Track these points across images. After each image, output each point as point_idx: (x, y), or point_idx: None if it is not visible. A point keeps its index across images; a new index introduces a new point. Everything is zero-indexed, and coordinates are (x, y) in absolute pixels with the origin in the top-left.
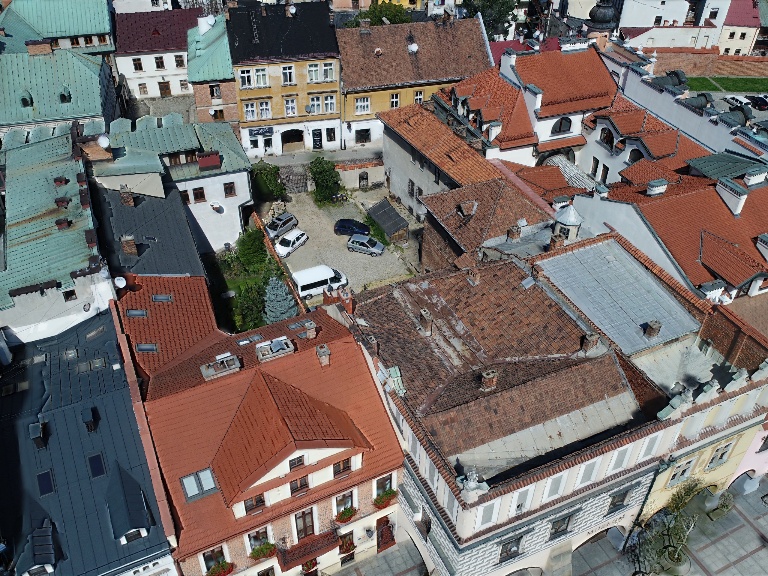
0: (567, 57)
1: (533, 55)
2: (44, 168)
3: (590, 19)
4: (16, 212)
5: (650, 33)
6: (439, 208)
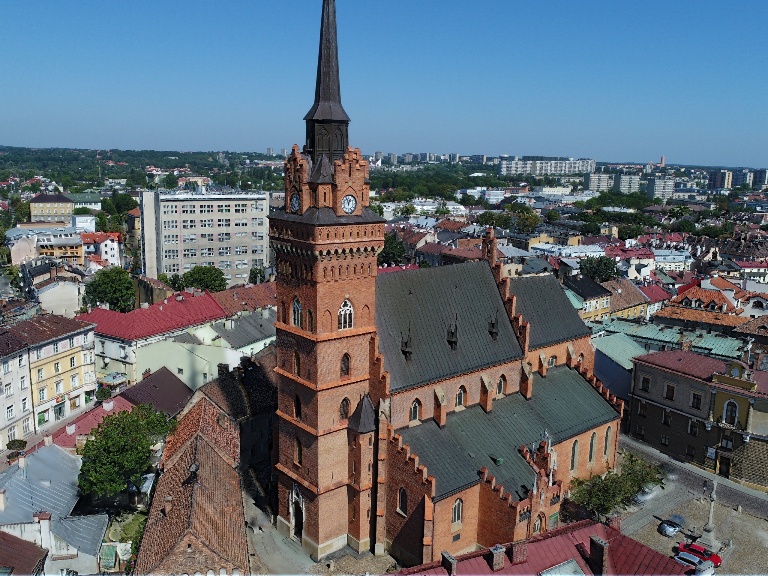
0: None
1: None
2: (639, 329)
3: None
4: (669, 339)
5: None
6: None
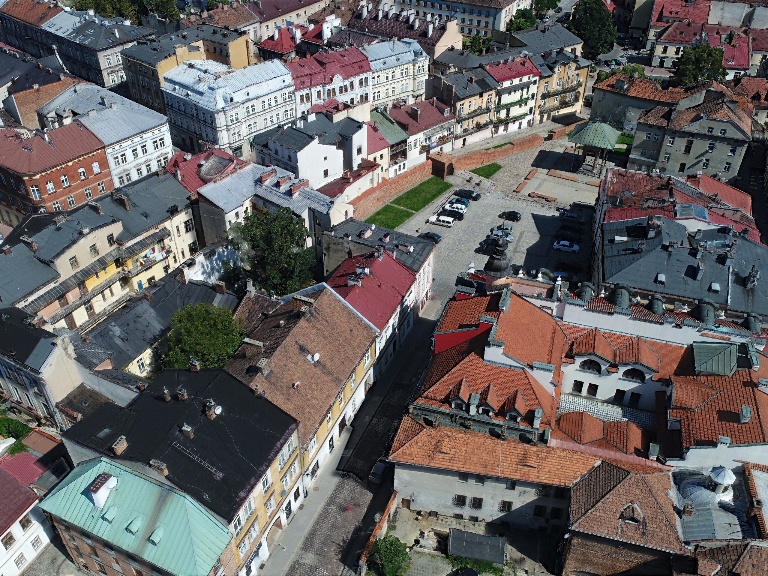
0: (510, 314)
1: (497, 330)
2: None
3: (488, 269)
4: None
5: (345, 193)
6: (604, 528)
